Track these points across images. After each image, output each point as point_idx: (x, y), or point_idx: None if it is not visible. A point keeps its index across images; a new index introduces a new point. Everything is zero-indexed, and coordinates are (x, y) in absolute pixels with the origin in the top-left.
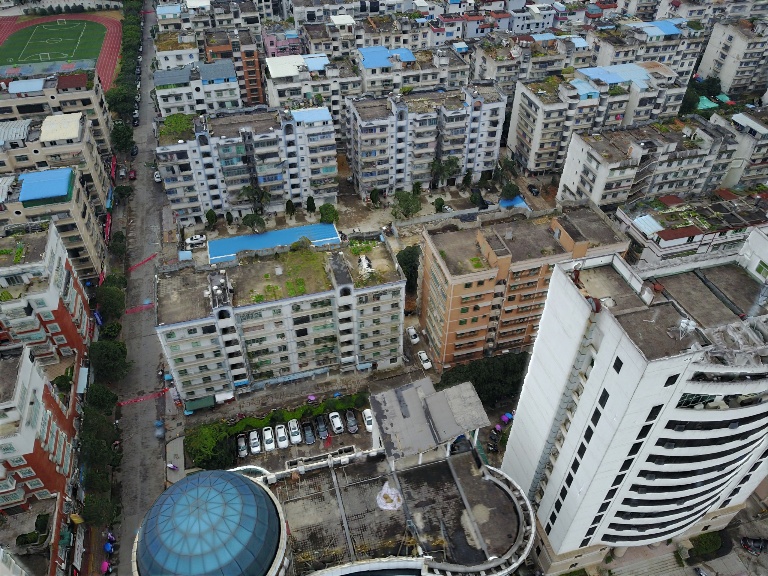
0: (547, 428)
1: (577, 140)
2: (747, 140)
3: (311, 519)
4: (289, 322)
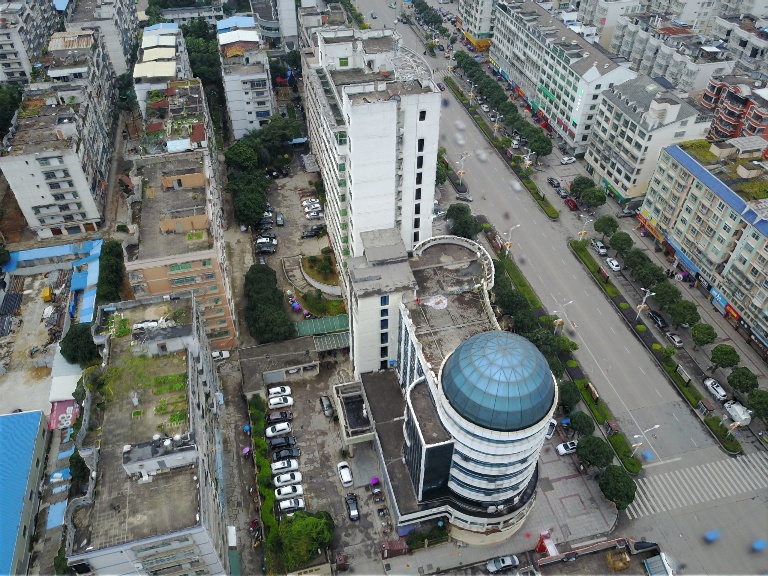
0: (393, 211)
1: (11, 161)
2: (81, 83)
3: (458, 345)
4: (197, 412)
